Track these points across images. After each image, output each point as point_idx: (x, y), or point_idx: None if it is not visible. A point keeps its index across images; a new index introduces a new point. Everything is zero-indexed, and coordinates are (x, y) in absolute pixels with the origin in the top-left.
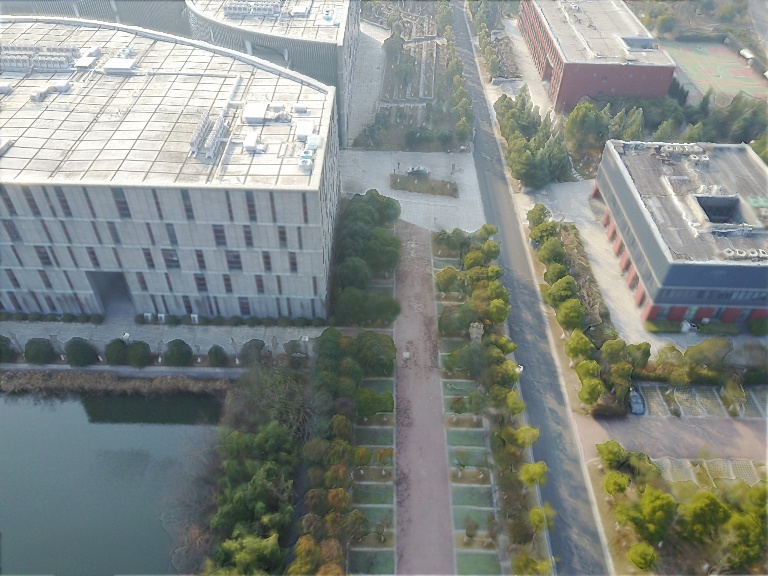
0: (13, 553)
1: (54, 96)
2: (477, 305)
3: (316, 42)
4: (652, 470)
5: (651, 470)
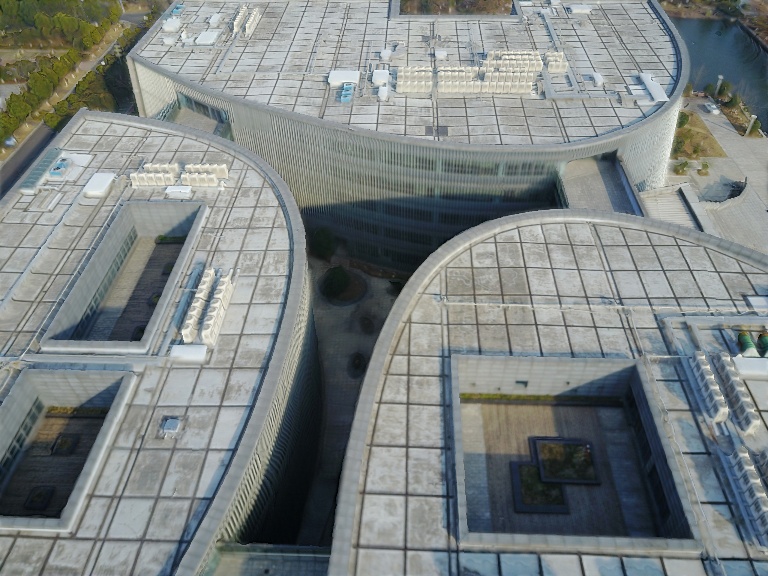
0: None
1: None
2: (104, 77)
3: None
4: (76, 38)
5: (77, 38)
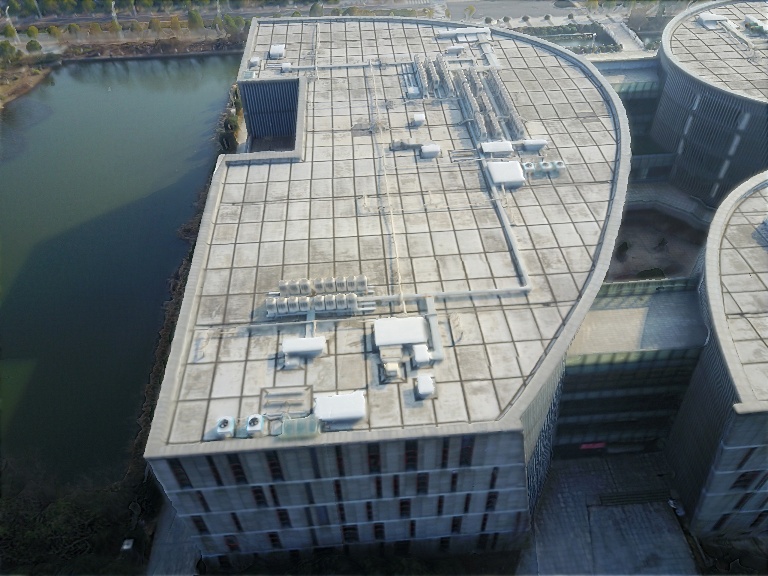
0: (2, 372)
1: (408, 154)
2: None
3: (726, 365)
4: None
5: None
